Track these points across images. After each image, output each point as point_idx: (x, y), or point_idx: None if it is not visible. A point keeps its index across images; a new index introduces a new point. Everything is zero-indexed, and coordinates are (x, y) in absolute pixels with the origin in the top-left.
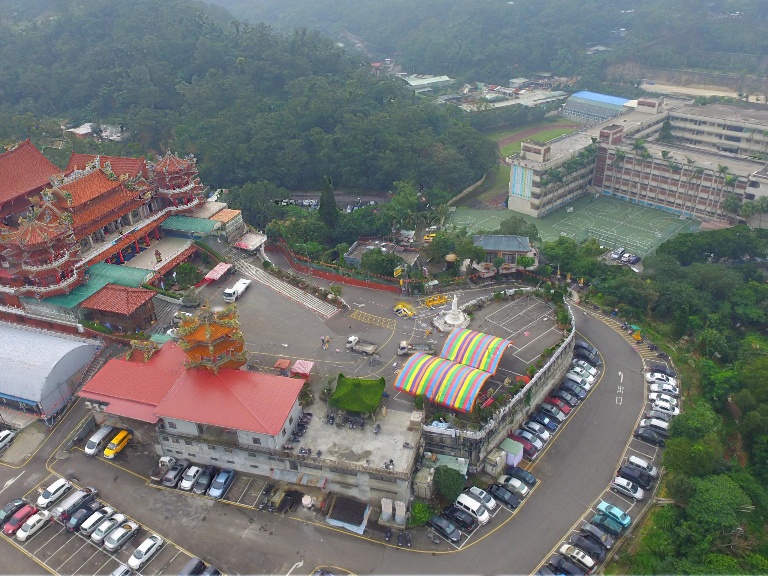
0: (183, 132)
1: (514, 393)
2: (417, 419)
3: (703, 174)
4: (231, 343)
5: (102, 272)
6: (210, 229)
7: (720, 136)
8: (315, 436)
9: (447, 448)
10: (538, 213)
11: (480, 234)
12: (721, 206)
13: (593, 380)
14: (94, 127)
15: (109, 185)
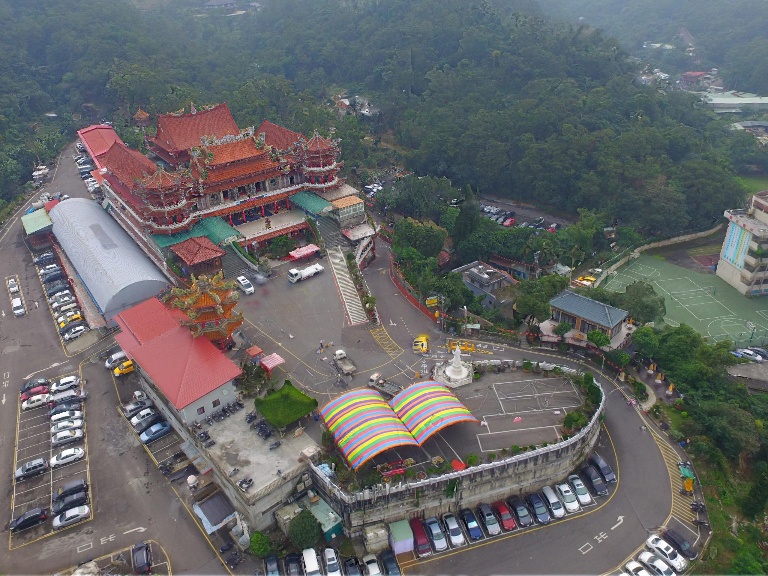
0: (411, 117)
1: (432, 475)
2: (308, 453)
3: None
4: (216, 316)
5: (207, 225)
6: (318, 211)
7: None
8: (227, 426)
9: (328, 496)
10: (747, 290)
11: (585, 291)
12: None
13: (575, 509)
14: (351, 100)
15: (253, 153)
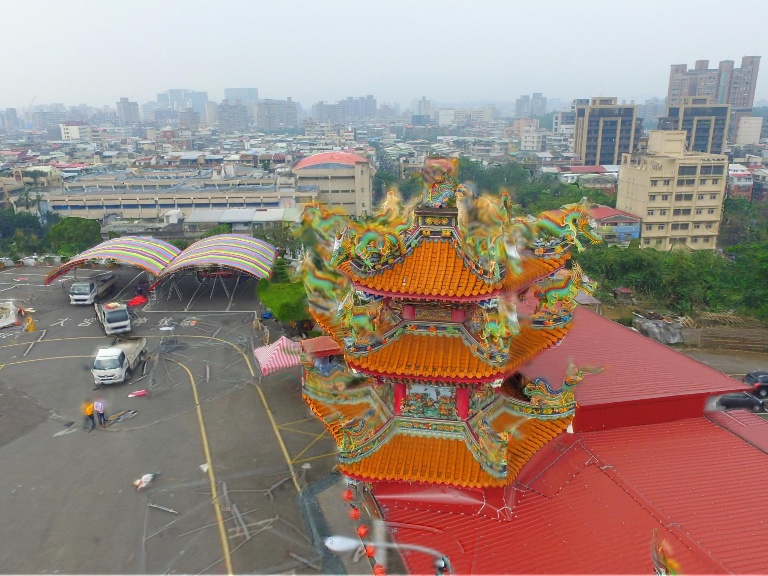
0: None
1: None
2: None
3: None
4: None
5: None
6: None
7: None
8: None
9: None
10: None
11: None
12: None
13: None
14: None
15: None
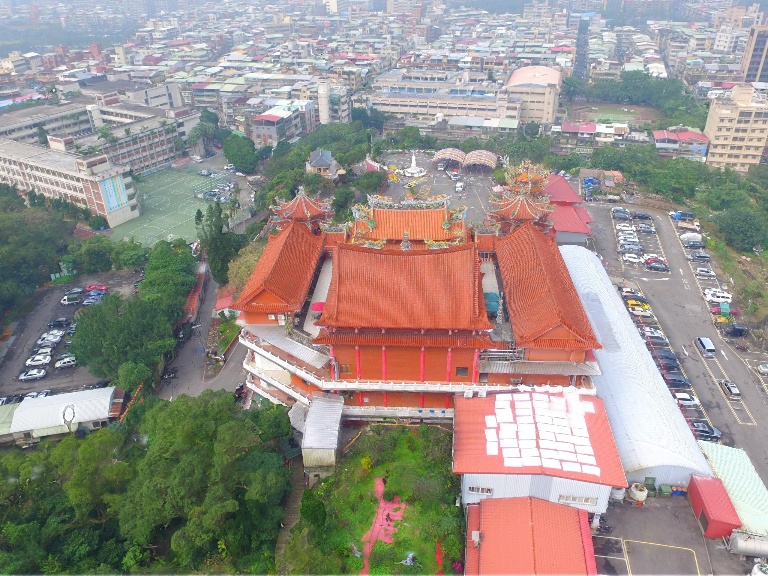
0: None
1: None
2: None
3: (152, 134)
4: None
5: None
6: None
7: (32, 136)
8: None
9: None
10: None
11: None
12: (170, 151)
13: None
14: None
15: None
